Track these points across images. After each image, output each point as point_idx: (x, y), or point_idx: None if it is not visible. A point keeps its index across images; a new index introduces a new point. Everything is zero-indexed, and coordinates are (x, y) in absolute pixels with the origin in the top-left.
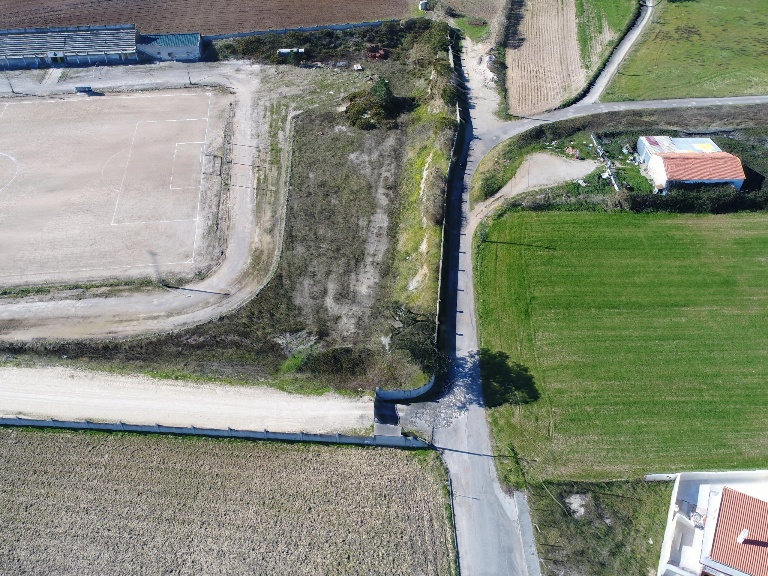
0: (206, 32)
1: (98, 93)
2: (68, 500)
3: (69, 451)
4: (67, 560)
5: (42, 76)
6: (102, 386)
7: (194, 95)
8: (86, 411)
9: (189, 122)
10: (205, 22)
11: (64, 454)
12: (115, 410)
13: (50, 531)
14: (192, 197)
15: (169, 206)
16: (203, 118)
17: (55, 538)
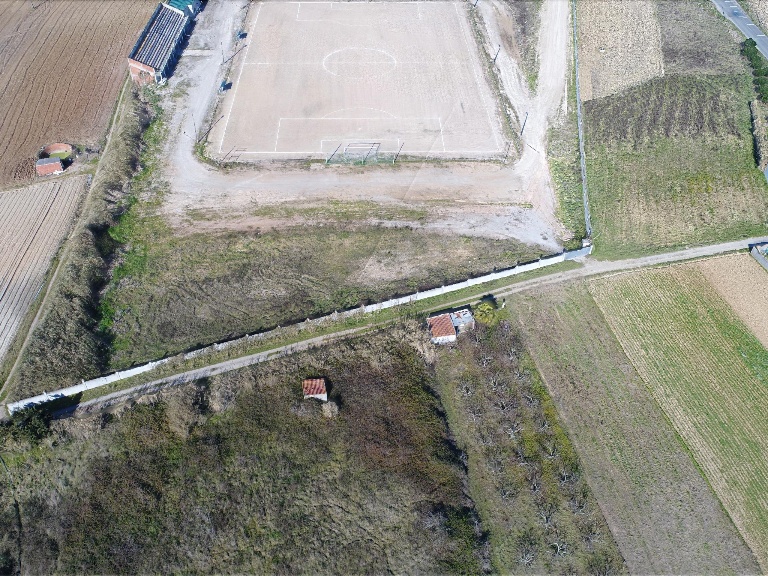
0: (151, 3)
1: (242, 35)
2: (607, 5)
3: (585, 7)
4: (630, 3)
5: (197, 57)
6: (551, 4)
7: (262, 7)
8: (565, 6)
9: (304, 7)
10: (124, 6)
11: (587, 8)
12: (564, 1)
13: (620, 7)
14: (395, 4)
15: (404, 8)
16: (299, 3)
17: (623, 6)
